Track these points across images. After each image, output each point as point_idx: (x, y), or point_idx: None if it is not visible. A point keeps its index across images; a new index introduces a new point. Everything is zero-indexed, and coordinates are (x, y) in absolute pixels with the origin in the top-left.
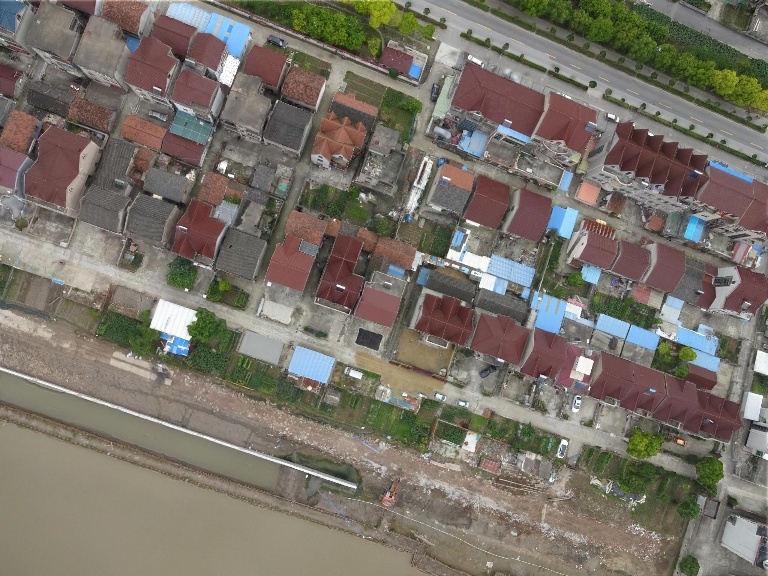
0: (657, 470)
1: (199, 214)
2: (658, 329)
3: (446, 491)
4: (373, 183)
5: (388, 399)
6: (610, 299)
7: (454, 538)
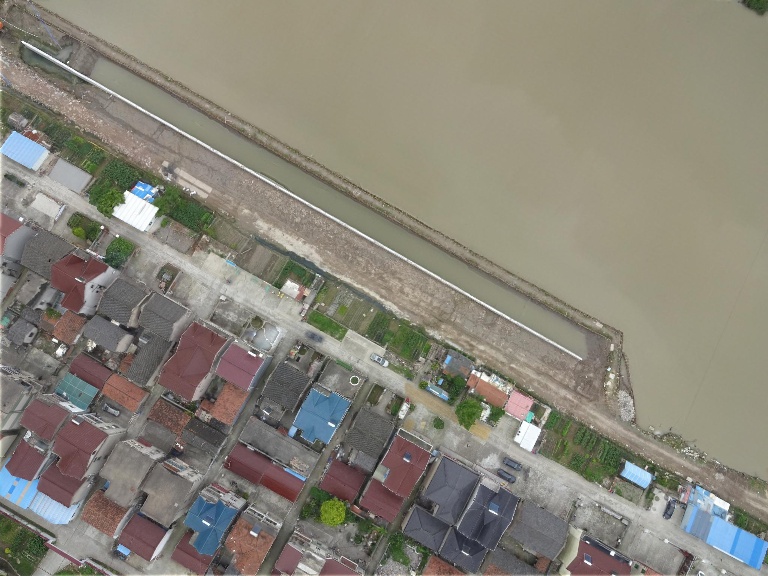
0: None
1: None
2: None
3: None
4: None
5: None
6: None
7: None
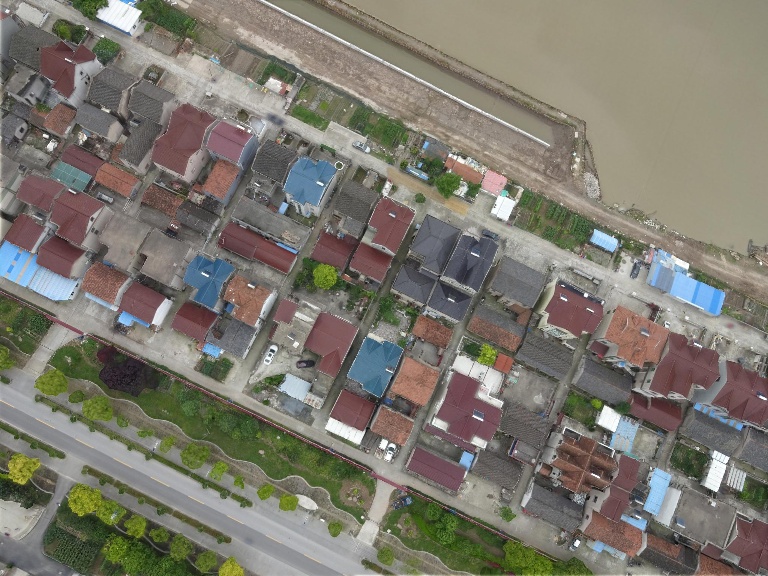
0: None
1: None
2: None
3: None
4: None
5: None
6: None
7: None
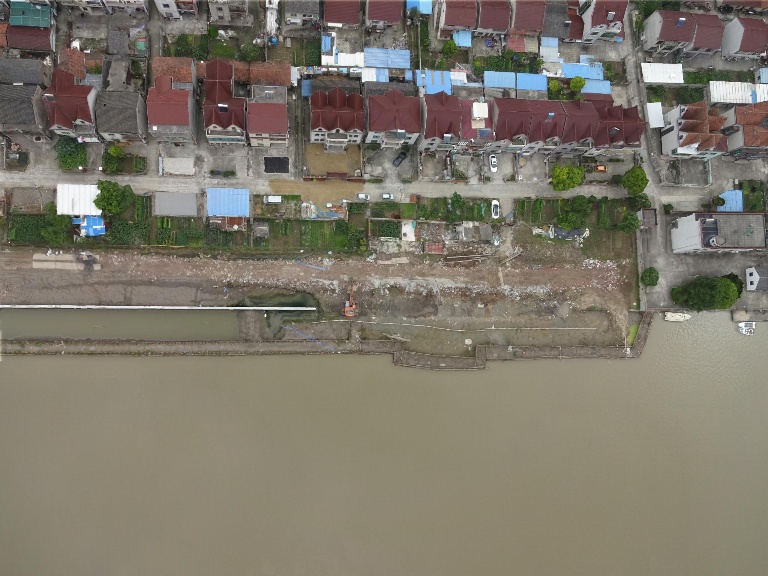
0: (589, 200)
1: (62, 82)
2: (543, 71)
3: (402, 285)
4: (227, 16)
5: (315, 214)
6: (490, 58)
7: (426, 328)
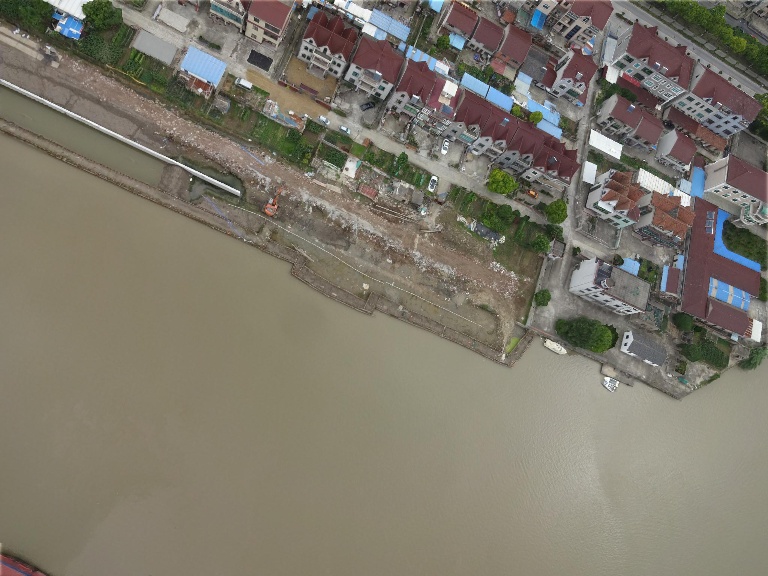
0: (514, 212)
1: None
2: (512, 96)
3: (327, 209)
4: None
5: (275, 114)
6: (473, 68)
7: (333, 257)
